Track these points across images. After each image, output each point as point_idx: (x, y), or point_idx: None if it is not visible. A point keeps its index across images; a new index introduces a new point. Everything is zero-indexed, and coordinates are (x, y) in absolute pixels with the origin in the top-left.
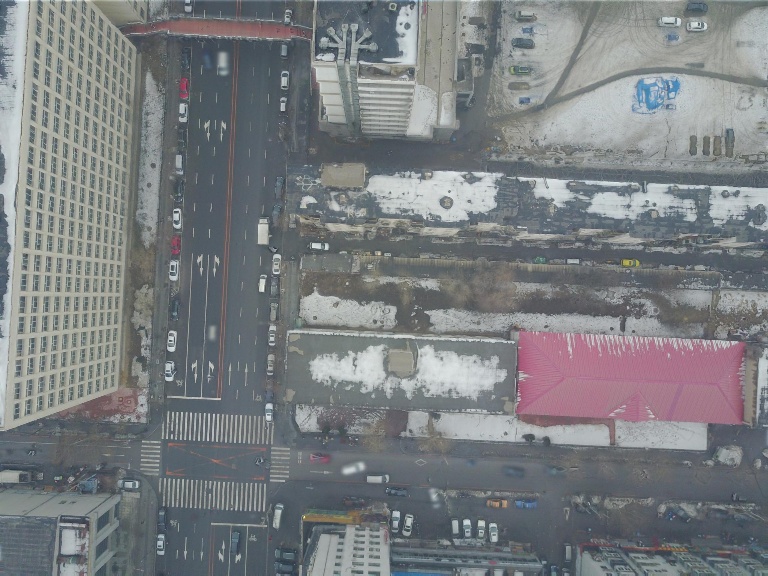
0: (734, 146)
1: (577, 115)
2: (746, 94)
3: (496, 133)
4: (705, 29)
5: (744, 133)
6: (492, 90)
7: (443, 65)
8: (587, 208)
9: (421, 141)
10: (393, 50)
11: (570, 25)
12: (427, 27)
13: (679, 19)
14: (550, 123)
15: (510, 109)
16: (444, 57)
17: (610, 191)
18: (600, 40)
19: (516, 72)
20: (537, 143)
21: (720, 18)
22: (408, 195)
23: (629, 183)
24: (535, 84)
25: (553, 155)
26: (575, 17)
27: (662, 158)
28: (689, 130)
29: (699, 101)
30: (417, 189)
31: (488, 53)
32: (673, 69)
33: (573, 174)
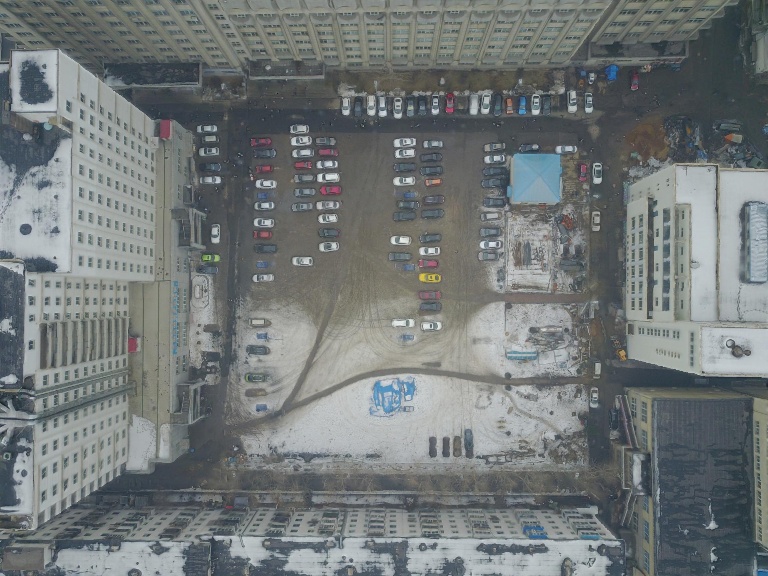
0: (474, 447)
1: (315, 420)
2: (484, 392)
3: (235, 441)
4: (439, 329)
5: (484, 432)
6: (229, 398)
7: (161, 396)
8: (284, 566)
9: (141, 474)
10: (11, 498)
11: (305, 329)
12: (143, 358)
13: (412, 321)
14: (288, 429)
15: (248, 416)
16: (161, 388)
17: (307, 548)
18: (335, 343)
19: (251, 381)
20: (276, 450)
21: (455, 315)
22: (97, 568)
23: (326, 538)
24: (272, 390)
25: (291, 463)
26: (309, 320)
27: (401, 462)
28: (428, 431)
29: (437, 401)
30: (105, 562)
31: (224, 360)
32: (410, 370)
33: (313, 481)
